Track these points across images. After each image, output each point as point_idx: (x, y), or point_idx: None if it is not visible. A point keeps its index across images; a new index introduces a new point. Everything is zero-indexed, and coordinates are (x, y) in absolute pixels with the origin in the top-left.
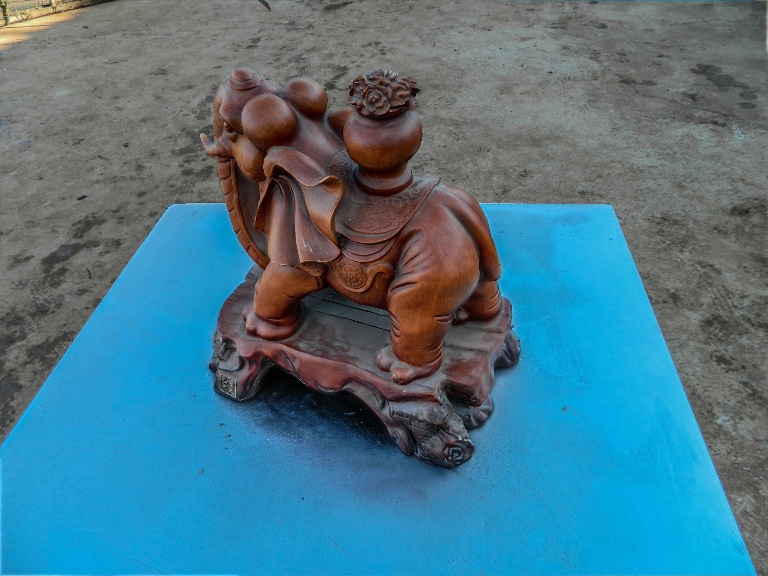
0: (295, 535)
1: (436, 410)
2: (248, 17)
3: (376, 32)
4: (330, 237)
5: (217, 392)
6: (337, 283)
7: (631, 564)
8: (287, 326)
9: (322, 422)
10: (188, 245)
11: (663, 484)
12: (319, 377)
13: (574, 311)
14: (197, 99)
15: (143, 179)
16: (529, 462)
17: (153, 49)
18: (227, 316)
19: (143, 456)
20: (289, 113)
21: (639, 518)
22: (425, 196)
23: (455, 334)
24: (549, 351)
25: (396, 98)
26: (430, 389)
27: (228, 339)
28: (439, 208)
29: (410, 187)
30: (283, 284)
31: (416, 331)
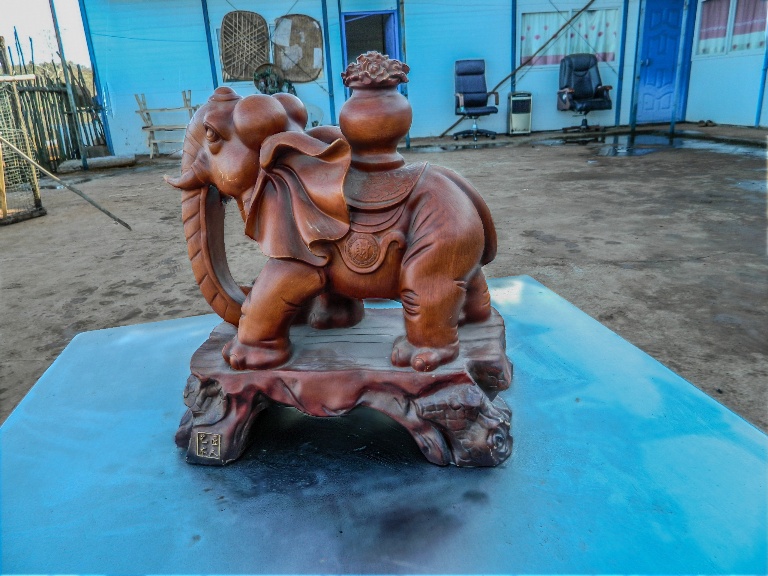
0: (347, 568)
1: (471, 391)
2: (108, 237)
3: (242, 236)
4: (341, 207)
5: (191, 463)
6: (343, 271)
7: (721, 496)
8: (281, 350)
9: (332, 462)
10: (110, 357)
11: (703, 432)
12: (327, 397)
13: (541, 337)
14: (61, 302)
15: (2, 377)
16: (571, 444)
17: (4, 269)
18: (201, 363)
19: (107, 544)
20: (282, 107)
21: (701, 461)
22: (423, 167)
23: (458, 334)
24: (536, 365)
25: (393, 69)
26: (459, 369)
27: (209, 381)
28: (439, 175)
29: (405, 166)
30: (281, 287)
31: (437, 300)
